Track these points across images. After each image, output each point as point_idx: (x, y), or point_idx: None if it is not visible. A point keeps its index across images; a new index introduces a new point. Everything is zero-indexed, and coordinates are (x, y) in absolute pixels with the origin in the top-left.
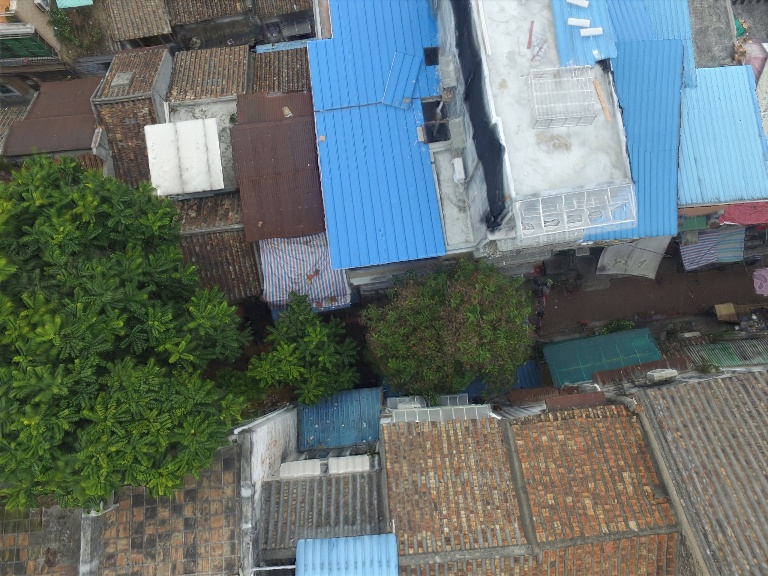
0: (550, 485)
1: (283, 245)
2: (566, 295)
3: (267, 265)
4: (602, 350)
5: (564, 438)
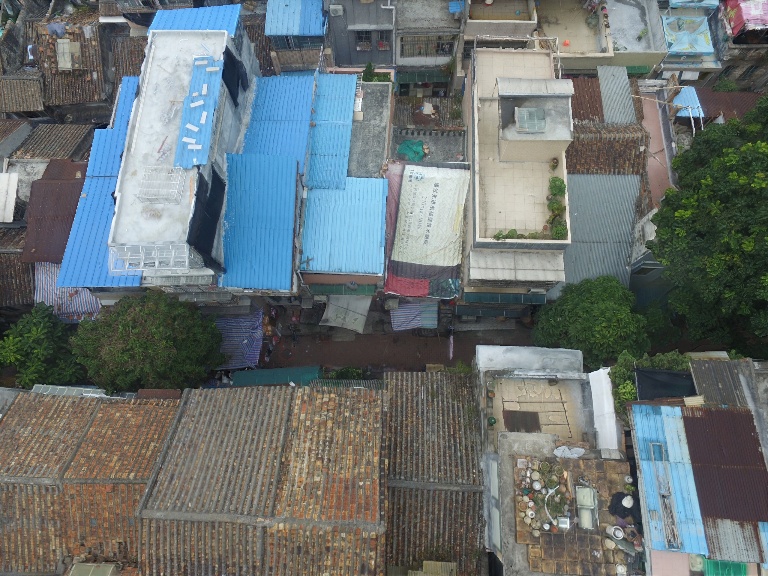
0: (99, 444)
1: (53, 268)
2: (318, 342)
3: (40, 282)
4: (276, 379)
5: (131, 416)
